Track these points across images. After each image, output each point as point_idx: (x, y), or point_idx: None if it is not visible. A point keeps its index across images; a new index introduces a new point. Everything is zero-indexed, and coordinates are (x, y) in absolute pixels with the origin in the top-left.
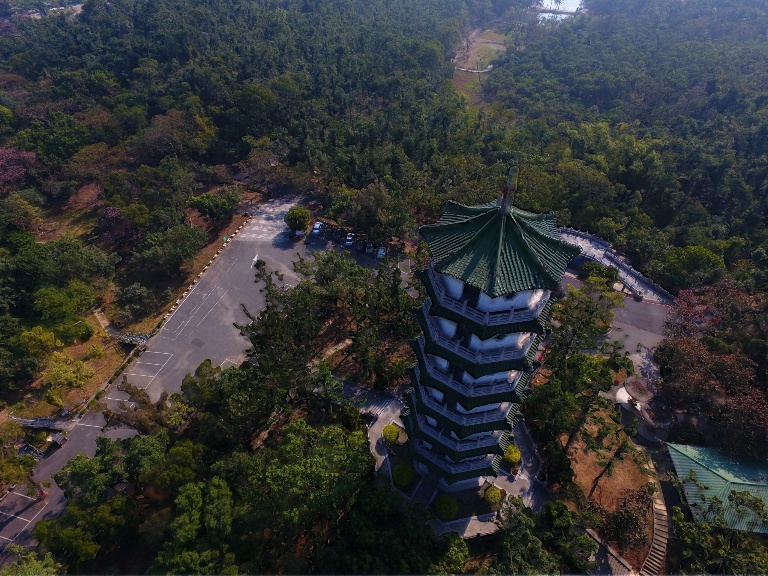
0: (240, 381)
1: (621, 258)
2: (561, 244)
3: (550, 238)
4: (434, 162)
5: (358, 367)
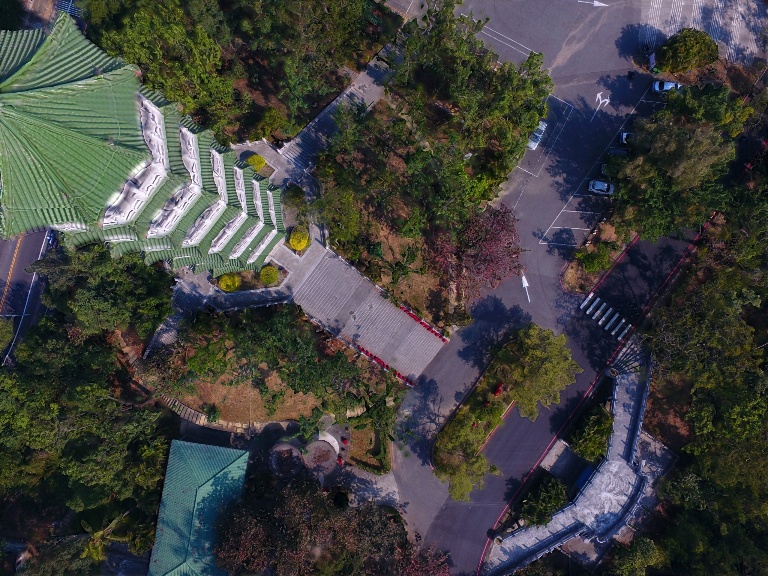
0: (346, 6)
1: (592, 554)
2: (0, 205)
3: (0, 188)
4: None
5: (372, 143)
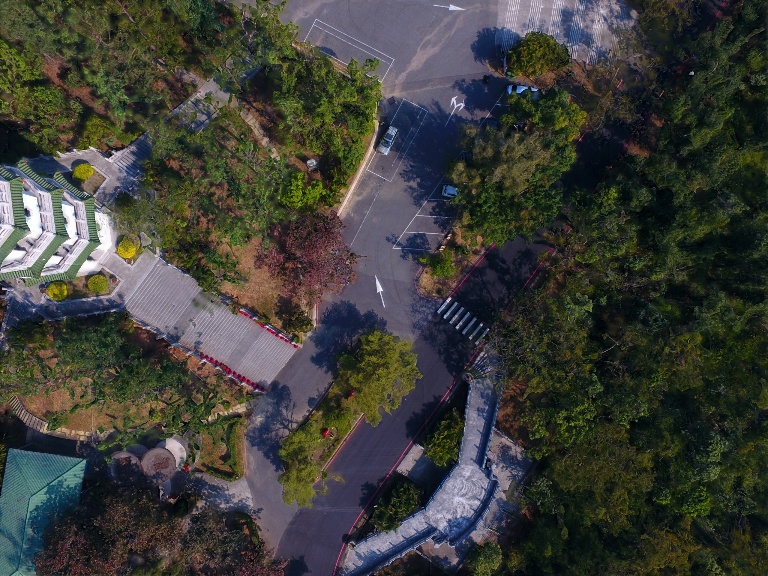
0: None
1: (453, 558)
2: None
3: None
4: (716, 300)
5: None
